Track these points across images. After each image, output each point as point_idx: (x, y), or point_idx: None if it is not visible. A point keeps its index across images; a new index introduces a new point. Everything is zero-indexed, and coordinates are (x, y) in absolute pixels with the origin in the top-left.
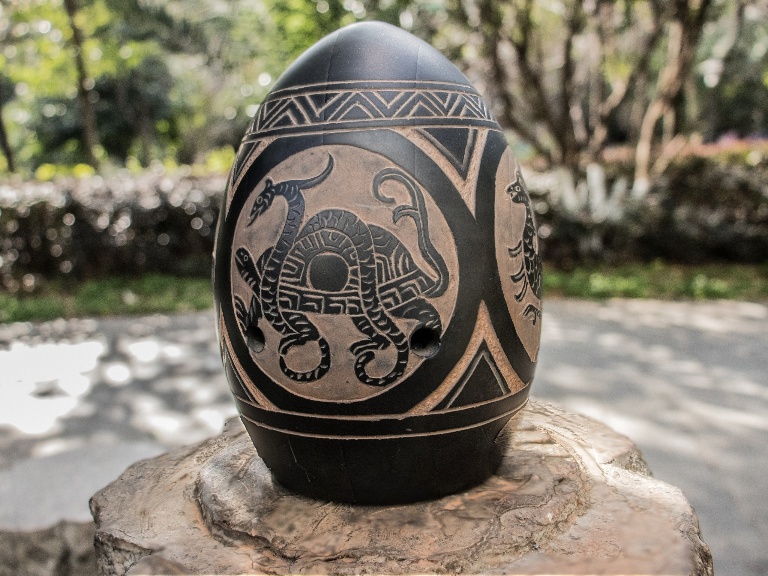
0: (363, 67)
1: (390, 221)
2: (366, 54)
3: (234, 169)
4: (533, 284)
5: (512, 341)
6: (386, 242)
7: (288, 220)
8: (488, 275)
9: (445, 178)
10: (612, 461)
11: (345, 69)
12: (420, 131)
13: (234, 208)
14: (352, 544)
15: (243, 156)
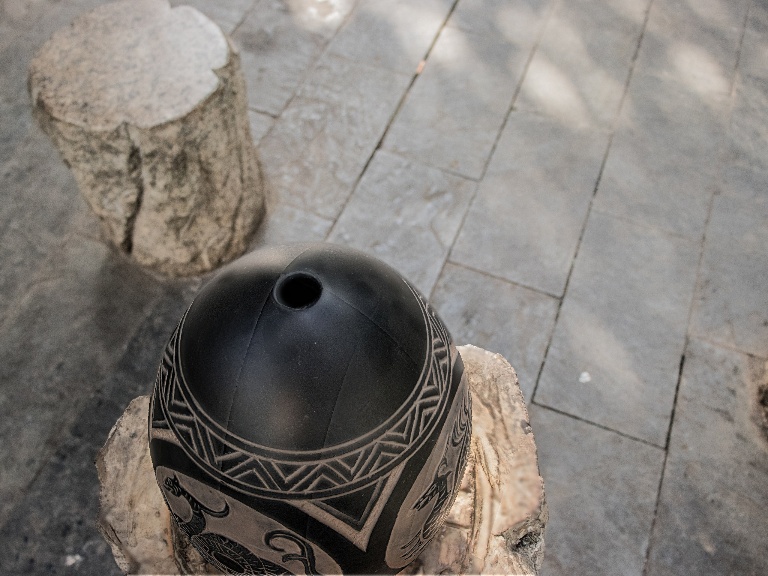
0: (265, 428)
1: (279, 560)
2: (272, 407)
3: (153, 404)
4: None
5: None
6: (275, 569)
7: (193, 520)
8: (374, 570)
9: (337, 535)
10: (505, 531)
11: (246, 423)
12: (317, 504)
13: (154, 449)
14: None
15: (157, 414)
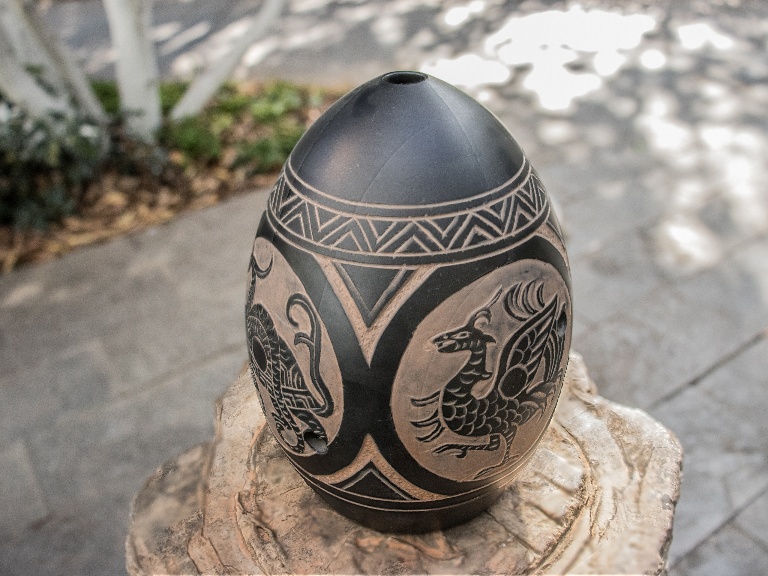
0: (322, 171)
1: (292, 341)
2: (335, 152)
3: None
4: (460, 427)
5: (413, 469)
6: (287, 357)
7: (249, 294)
8: (377, 417)
9: (346, 321)
10: None
11: (311, 166)
12: (337, 266)
13: None
14: (279, 527)
15: None
